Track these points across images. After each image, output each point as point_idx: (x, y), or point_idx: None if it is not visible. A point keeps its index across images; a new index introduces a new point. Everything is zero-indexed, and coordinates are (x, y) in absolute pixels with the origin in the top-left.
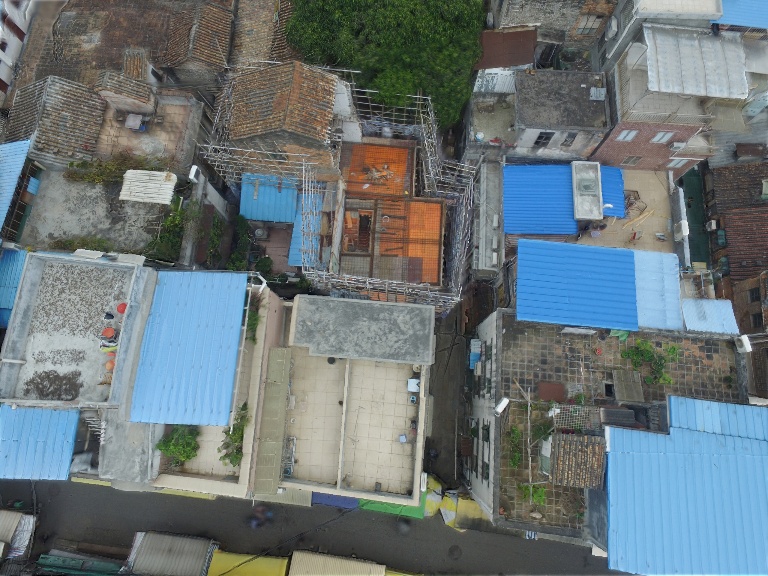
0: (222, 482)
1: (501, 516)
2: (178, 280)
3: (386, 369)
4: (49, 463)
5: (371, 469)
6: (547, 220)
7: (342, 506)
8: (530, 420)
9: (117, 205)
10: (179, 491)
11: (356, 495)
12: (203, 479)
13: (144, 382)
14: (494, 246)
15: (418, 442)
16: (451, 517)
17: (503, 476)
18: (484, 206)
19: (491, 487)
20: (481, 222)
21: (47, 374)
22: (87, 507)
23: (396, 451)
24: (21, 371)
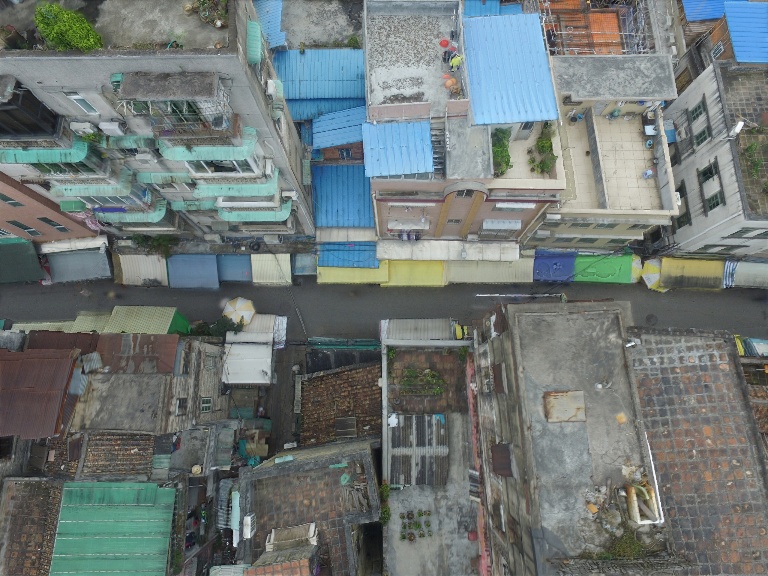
0: (544, 180)
1: (752, 212)
2: (481, 23)
3: (619, 125)
4: (415, 161)
5: (624, 201)
6: (723, 6)
7: (559, 279)
8: (758, 142)
9: (355, 15)
10: (414, 282)
11: (625, 212)
12: (528, 179)
13: (477, 97)
14: (672, 40)
15: (668, 168)
16: (655, 279)
17: (745, 185)
18: (653, 12)
19: (733, 198)
20: (653, 25)
21: (395, 97)
22: (318, 318)
23: (642, 185)
24: (372, 97)
